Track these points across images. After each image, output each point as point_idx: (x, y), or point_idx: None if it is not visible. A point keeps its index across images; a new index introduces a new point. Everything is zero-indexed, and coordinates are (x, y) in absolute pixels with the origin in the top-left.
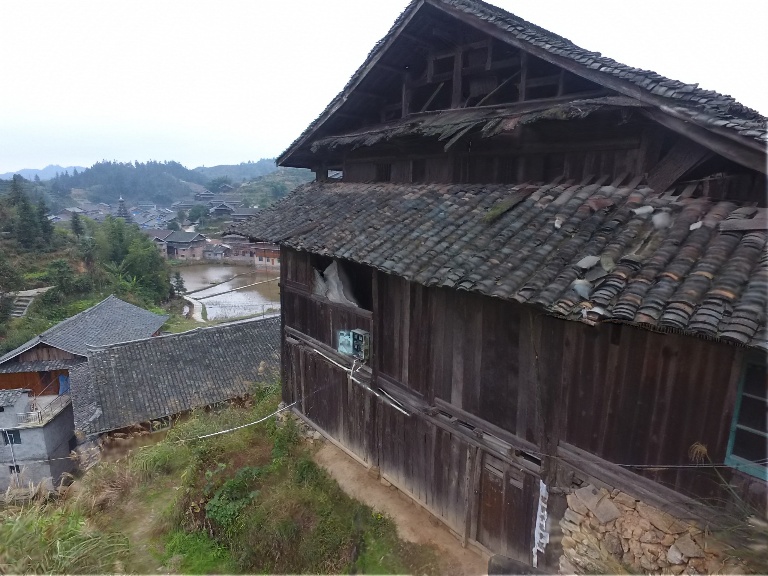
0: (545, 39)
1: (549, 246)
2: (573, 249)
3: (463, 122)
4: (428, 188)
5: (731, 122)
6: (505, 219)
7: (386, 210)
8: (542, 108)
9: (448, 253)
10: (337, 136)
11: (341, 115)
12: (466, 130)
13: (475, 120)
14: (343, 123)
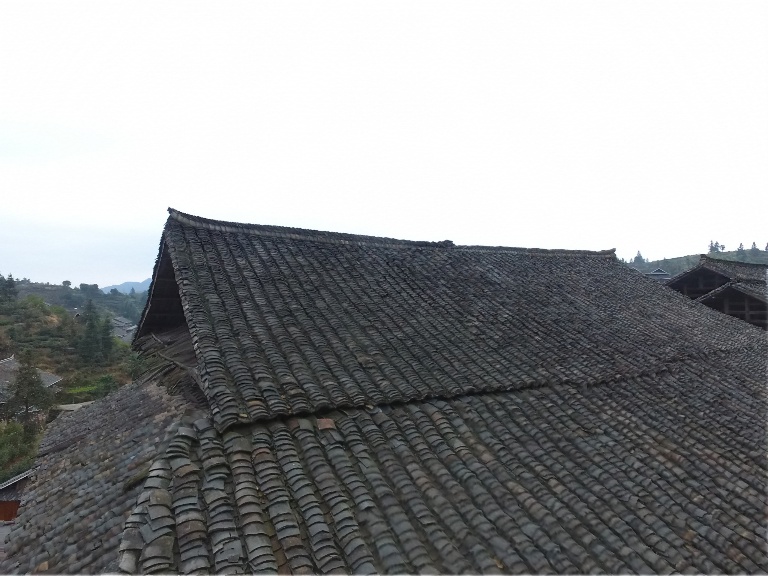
0: (187, 299)
1: (91, 557)
2: (91, 572)
3: (166, 359)
4: (179, 408)
5: (158, 468)
6: (137, 488)
7: (126, 434)
8: (185, 367)
9: (47, 535)
10: (153, 335)
11: (161, 314)
12: (155, 372)
13: (169, 360)
14: (169, 320)
